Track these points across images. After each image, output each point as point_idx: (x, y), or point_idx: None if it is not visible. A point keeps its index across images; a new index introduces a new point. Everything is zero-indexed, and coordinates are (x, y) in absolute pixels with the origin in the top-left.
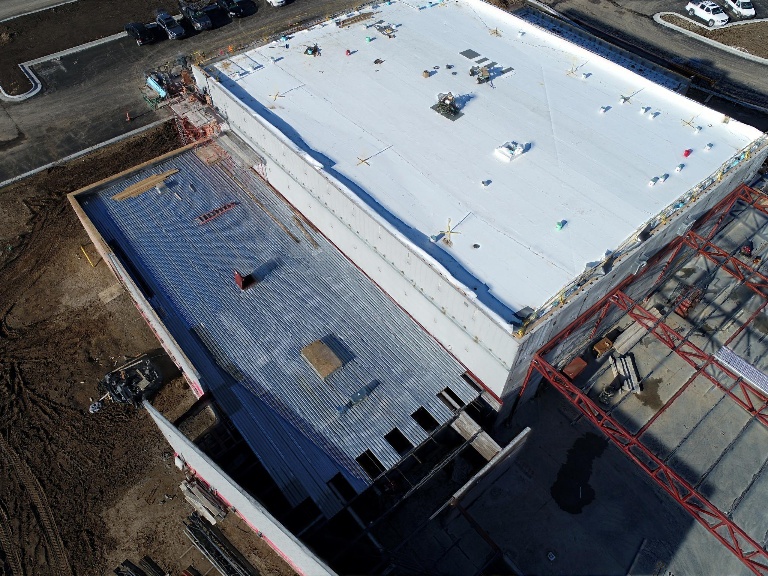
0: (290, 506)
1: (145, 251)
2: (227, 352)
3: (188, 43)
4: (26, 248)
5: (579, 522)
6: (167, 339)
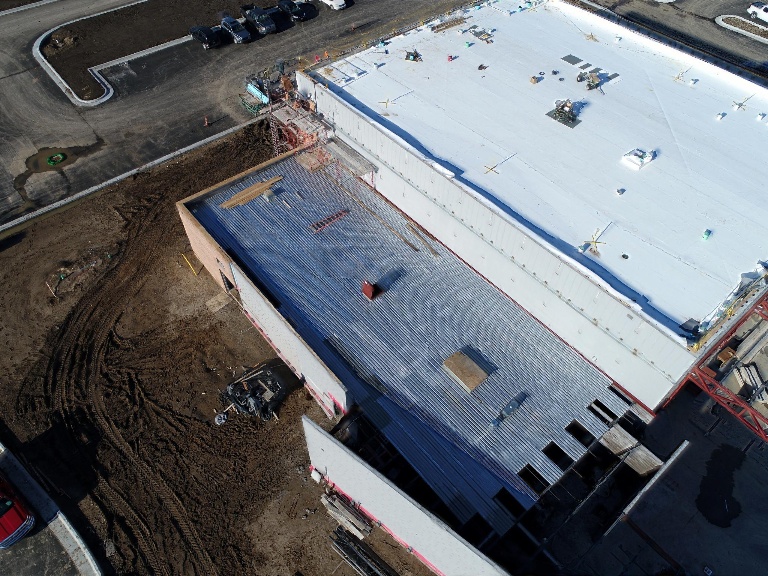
0: (459, 522)
1: (263, 260)
2: (366, 364)
3: (254, 47)
4: (125, 256)
5: (730, 536)
6: (299, 350)
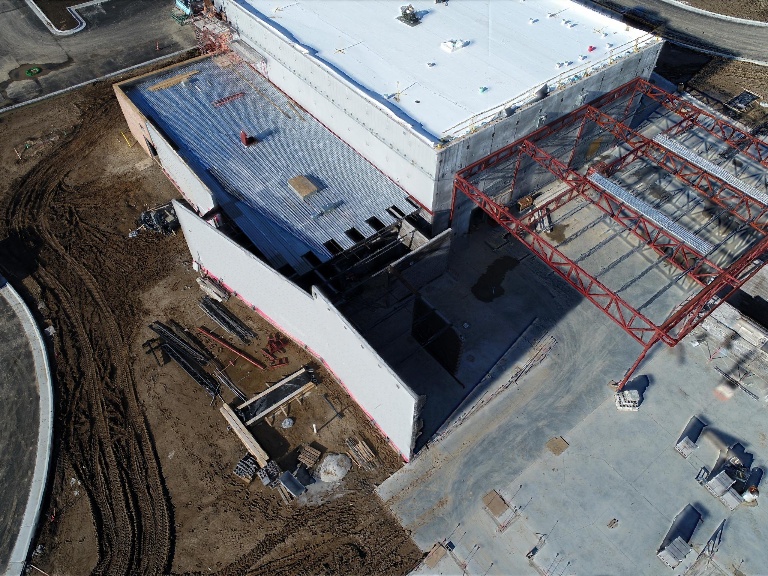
0: None
1: (173, 123)
2: (233, 183)
3: None
4: (78, 135)
5: (490, 307)
6: (189, 178)
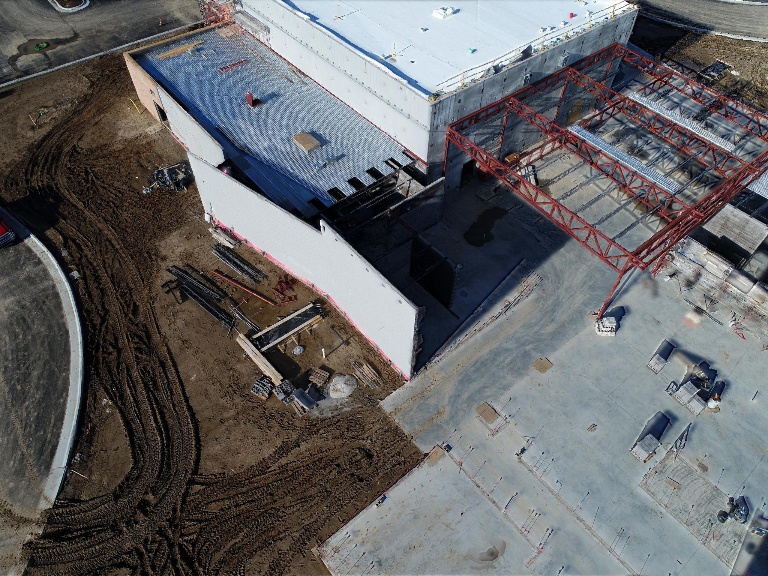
0: None
1: (182, 87)
2: (241, 140)
3: None
4: (88, 103)
5: (481, 250)
6: (199, 136)
